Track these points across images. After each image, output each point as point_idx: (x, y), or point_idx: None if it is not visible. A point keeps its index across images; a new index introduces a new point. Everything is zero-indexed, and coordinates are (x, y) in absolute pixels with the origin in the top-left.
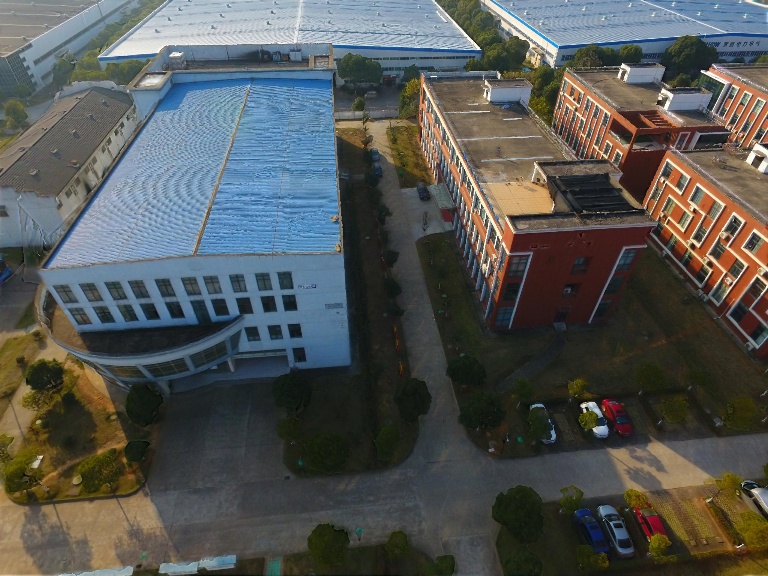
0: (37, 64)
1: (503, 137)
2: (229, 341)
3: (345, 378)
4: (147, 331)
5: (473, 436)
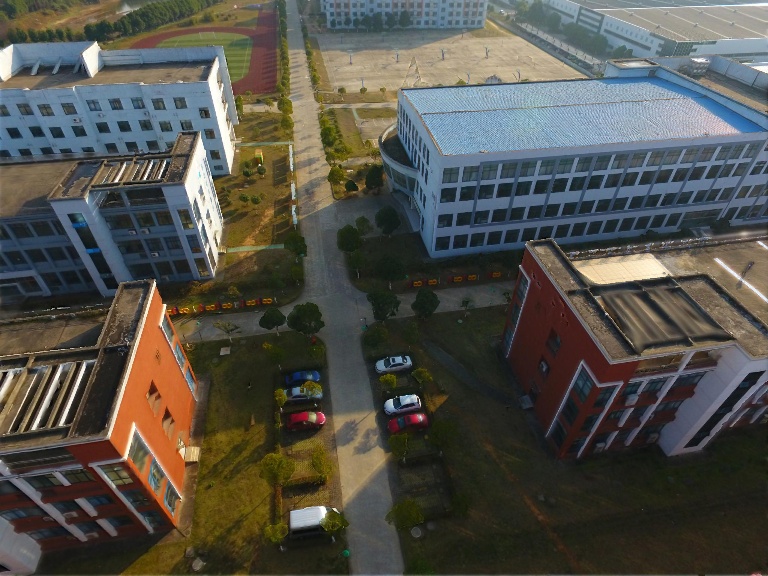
0: None
1: None
2: (408, 179)
3: (419, 257)
4: (403, 150)
5: (378, 322)
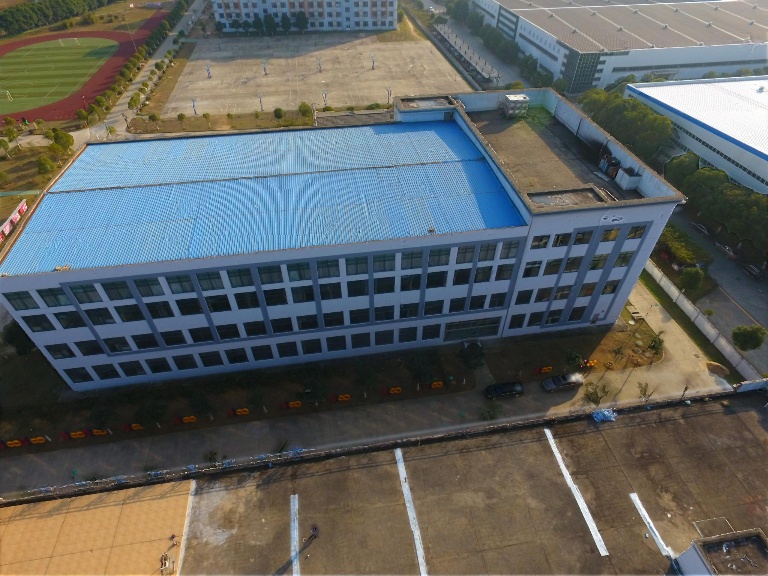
0: (617, 71)
1: (426, 568)
2: None
3: (60, 388)
4: None
5: None
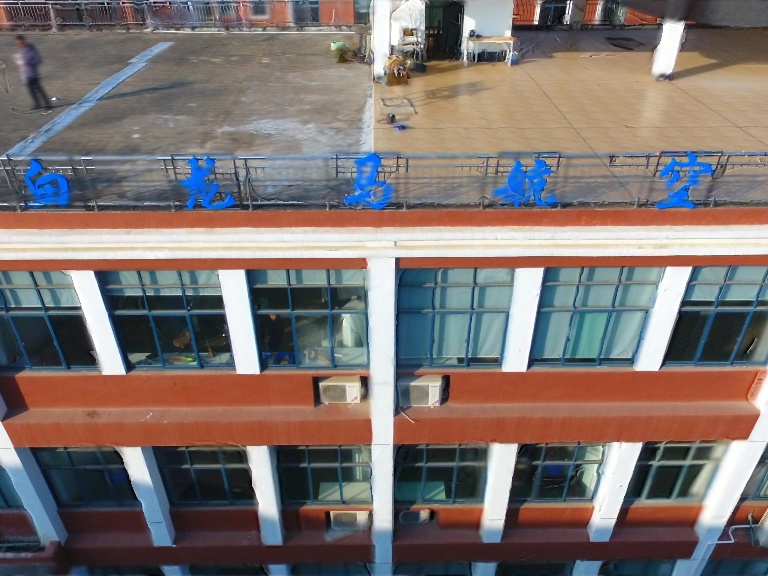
0: None
1: None
2: None
3: None
4: None
5: None
